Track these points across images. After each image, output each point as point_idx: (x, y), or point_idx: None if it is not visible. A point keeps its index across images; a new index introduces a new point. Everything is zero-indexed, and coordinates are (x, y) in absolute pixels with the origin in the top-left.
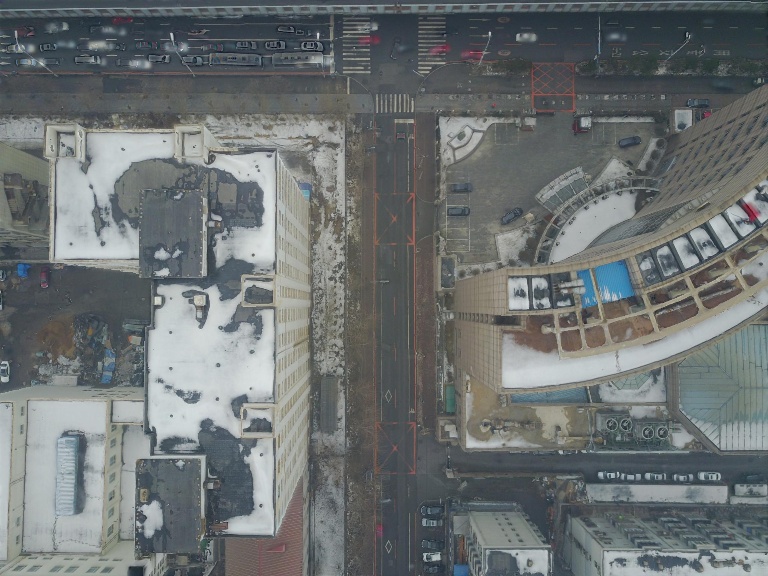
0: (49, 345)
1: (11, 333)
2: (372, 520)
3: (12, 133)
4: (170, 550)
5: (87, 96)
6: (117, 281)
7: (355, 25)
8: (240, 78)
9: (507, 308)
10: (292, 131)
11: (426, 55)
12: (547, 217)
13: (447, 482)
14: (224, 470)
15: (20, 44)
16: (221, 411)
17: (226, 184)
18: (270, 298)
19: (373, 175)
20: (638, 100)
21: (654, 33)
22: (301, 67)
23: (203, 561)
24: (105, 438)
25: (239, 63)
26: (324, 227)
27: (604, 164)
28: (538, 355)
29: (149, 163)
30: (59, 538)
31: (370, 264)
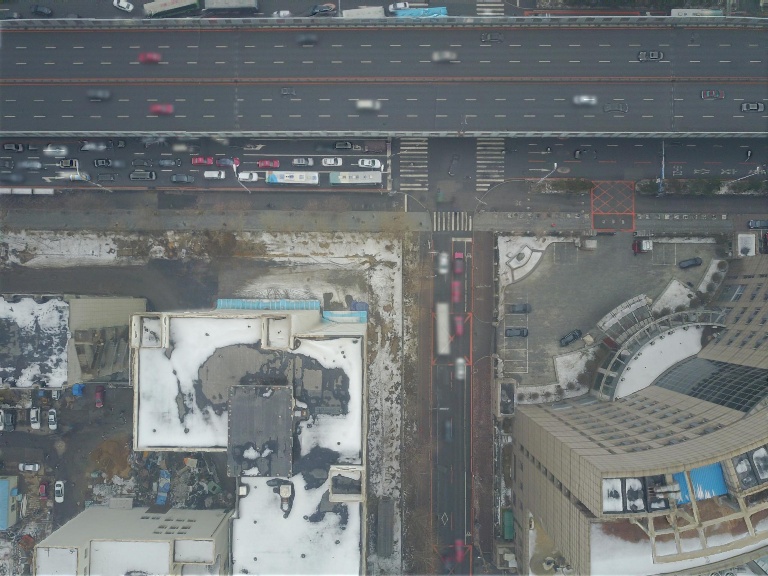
0: (104, 466)
1: (65, 452)
2: None
3: (66, 249)
4: None
5: (142, 212)
6: None
7: (413, 141)
8: (296, 194)
9: (601, 512)
10: (349, 249)
11: (484, 172)
12: (606, 340)
13: None
14: None
15: (81, 173)
16: None
17: (311, 370)
18: (356, 488)
19: (430, 294)
20: (699, 220)
21: (716, 151)
22: (358, 184)
23: None
24: None
25: (296, 182)
26: (381, 347)
27: (664, 285)
28: (626, 545)
29: (233, 348)
30: None
31: (427, 384)
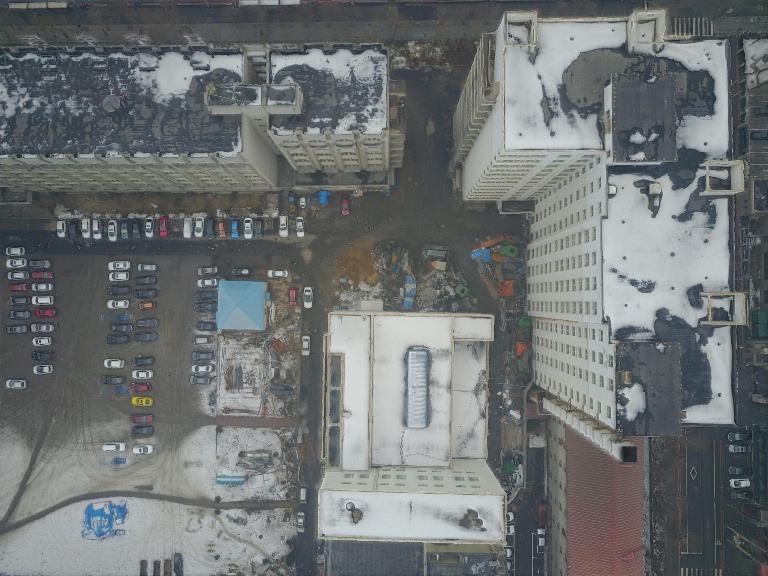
0: (352, 271)
1: (312, 260)
2: (676, 446)
3: None
4: (653, 433)
5: (383, 24)
6: (416, 208)
7: None
8: None
9: None
10: None
11: None
12: None
13: (753, 409)
14: (681, 359)
15: None
16: (677, 300)
17: None
18: (724, 187)
19: None
20: None
21: None
22: None
23: (512, 484)
24: (450, 353)
25: None
26: None
27: None
28: None
29: (597, 53)
30: (407, 452)
31: None
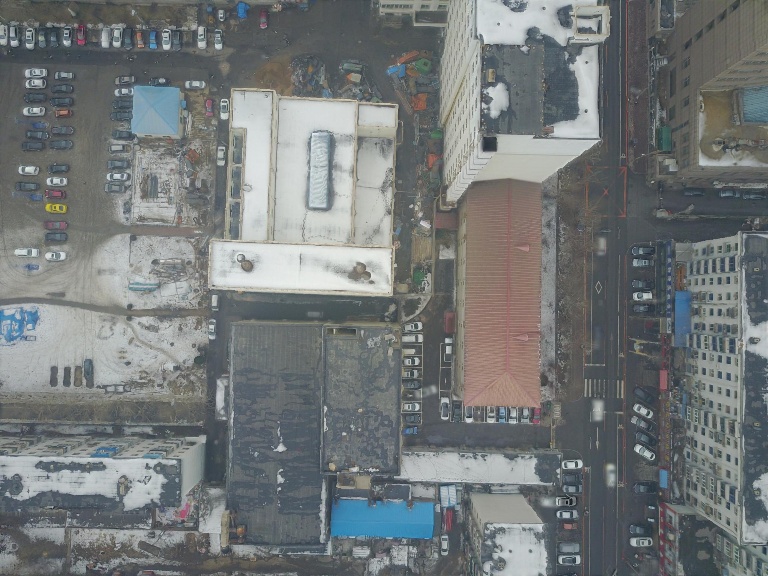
0: (269, 82)
1: (230, 73)
2: (583, 261)
3: None
4: (515, 131)
5: None
6: (334, 24)
7: None
8: None
9: None
10: None
11: None
12: None
13: (657, 225)
14: (550, 77)
15: None
16: (547, 20)
17: None
18: None
19: None
20: None
21: None
22: None
23: (420, 293)
24: (354, 138)
25: None
26: None
27: None
28: None
29: None
30: (308, 234)
31: None
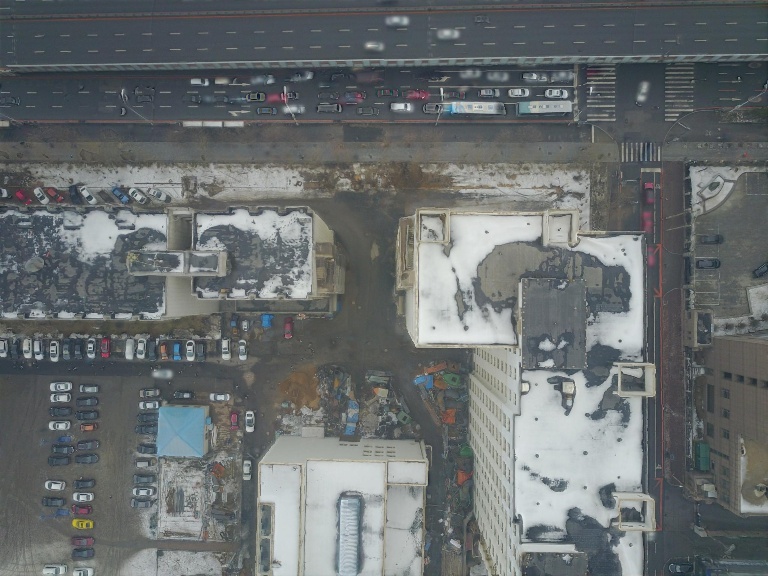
0: (294, 396)
1: (254, 383)
2: None
3: (254, 182)
4: None
5: (328, 145)
6: (359, 332)
7: (599, 71)
8: (482, 126)
9: None
10: (536, 181)
11: (673, 102)
12: None
13: (695, 540)
14: (592, 559)
15: None
16: (589, 500)
17: (591, 268)
18: (638, 385)
19: (618, 225)
20: None
21: None
22: (546, 115)
23: None
24: (383, 499)
25: (485, 112)
26: None
27: None
28: None
29: (512, 246)
30: None
31: None
